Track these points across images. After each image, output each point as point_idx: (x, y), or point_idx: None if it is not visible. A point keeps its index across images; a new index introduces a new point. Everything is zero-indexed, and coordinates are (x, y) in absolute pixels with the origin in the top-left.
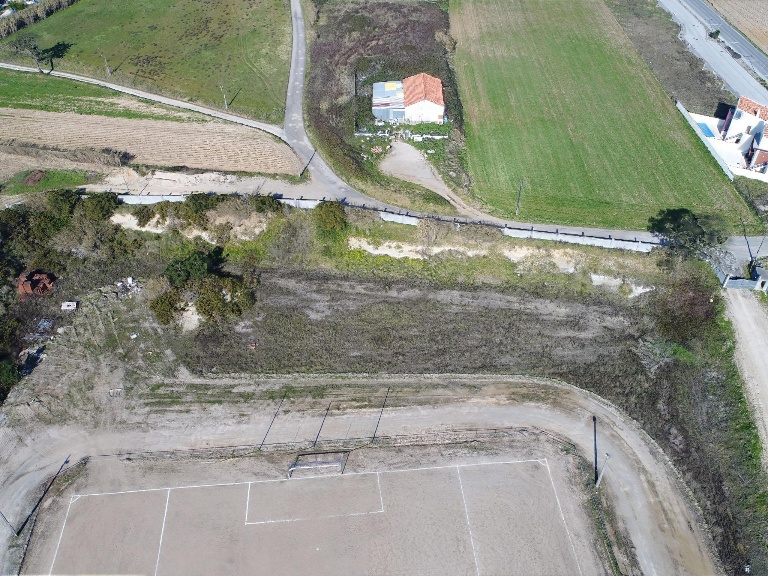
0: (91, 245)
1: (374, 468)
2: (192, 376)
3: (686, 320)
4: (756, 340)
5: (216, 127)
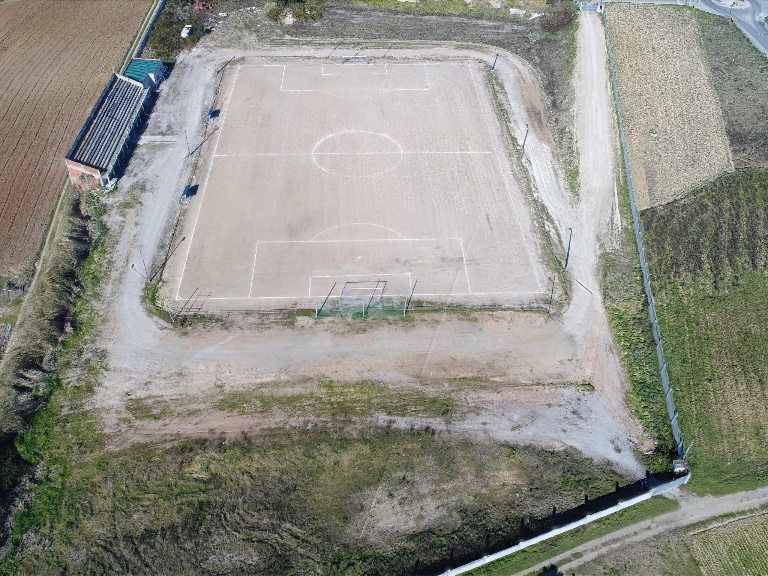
0: None
1: (384, 63)
2: (292, 37)
3: None
4: (589, 27)
5: None
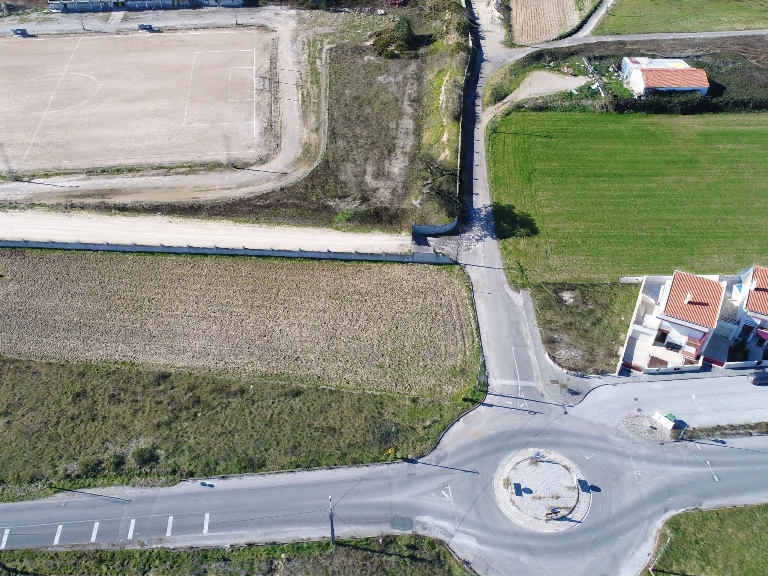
0: (429, 5)
1: (258, 98)
2: None
3: None
4: (344, 241)
5: (573, 14)
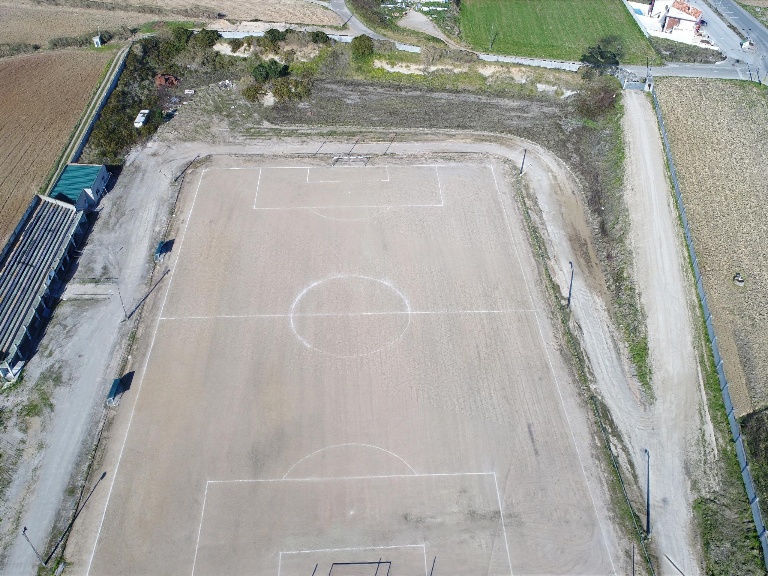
0: (201, 61)
1: (385, 164)
2: (271, 125)
3: (597, 109)
4: (637, 113)
5: (282, 1)
